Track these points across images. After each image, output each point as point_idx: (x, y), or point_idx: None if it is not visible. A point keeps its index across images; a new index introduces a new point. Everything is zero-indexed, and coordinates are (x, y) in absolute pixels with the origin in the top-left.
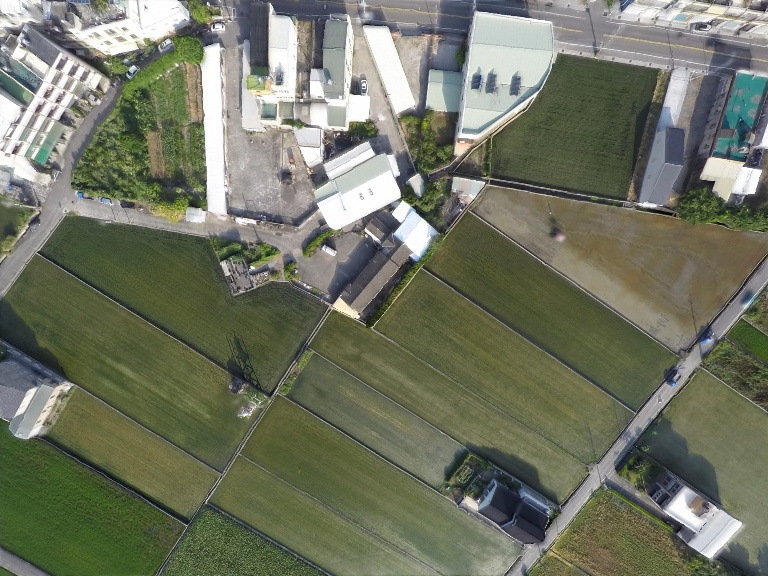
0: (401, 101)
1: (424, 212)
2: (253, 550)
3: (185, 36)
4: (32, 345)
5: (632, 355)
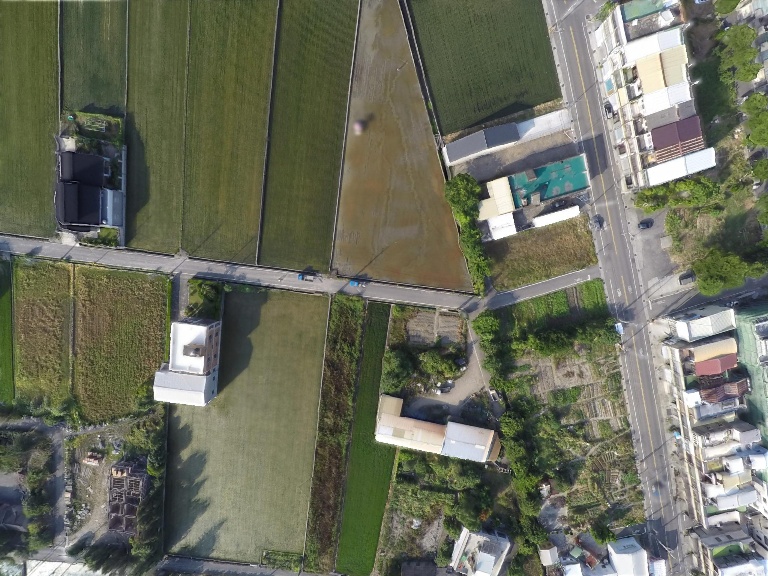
0: None
1: None
2: None
3: None
4: None
5: (308, 228)
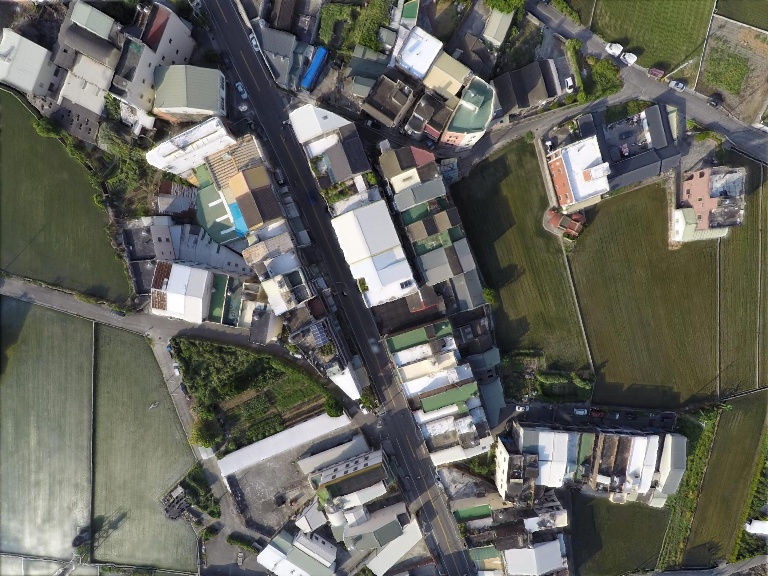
0: (377, 565)
1: None
2: None
3: (338, 409)
4: (3, 344)
5: None
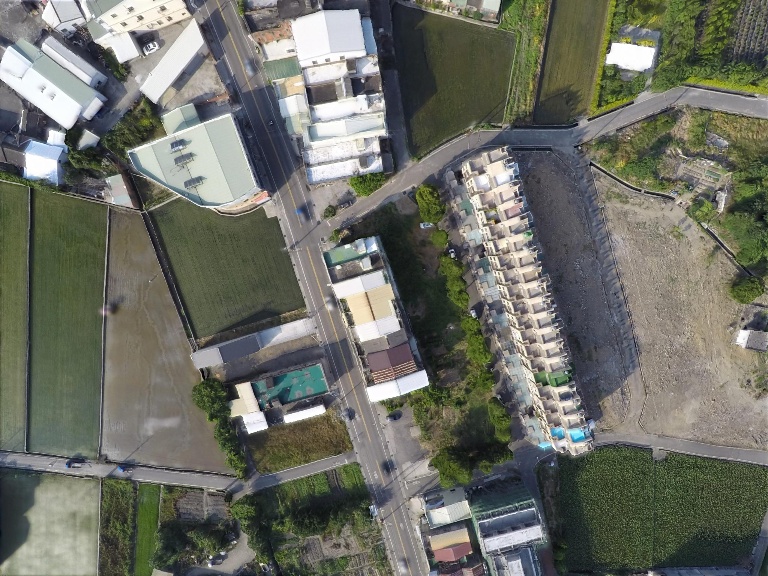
0: (153, 89)
1: None
2: None
3: None
4: None
5: (75, 419)
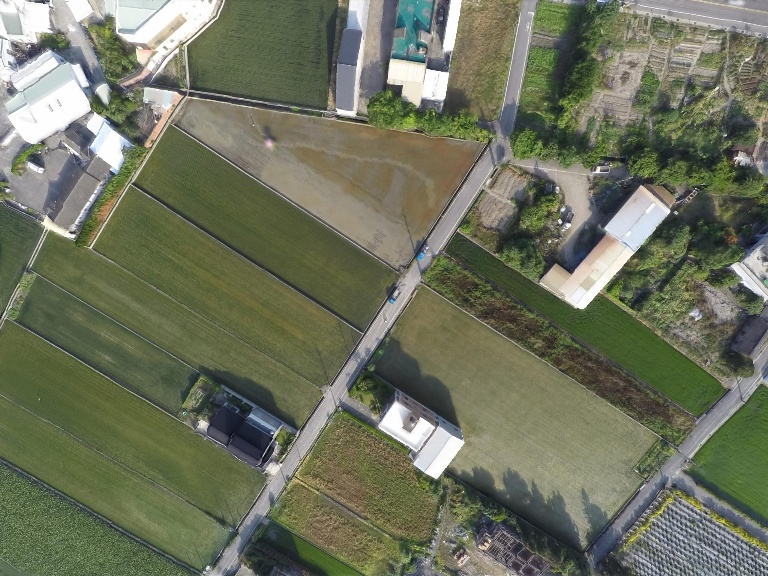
0: (80, 8)
1: (118, 124)
2: (1, 480)
3: None
4: None
5: (352, 272)
